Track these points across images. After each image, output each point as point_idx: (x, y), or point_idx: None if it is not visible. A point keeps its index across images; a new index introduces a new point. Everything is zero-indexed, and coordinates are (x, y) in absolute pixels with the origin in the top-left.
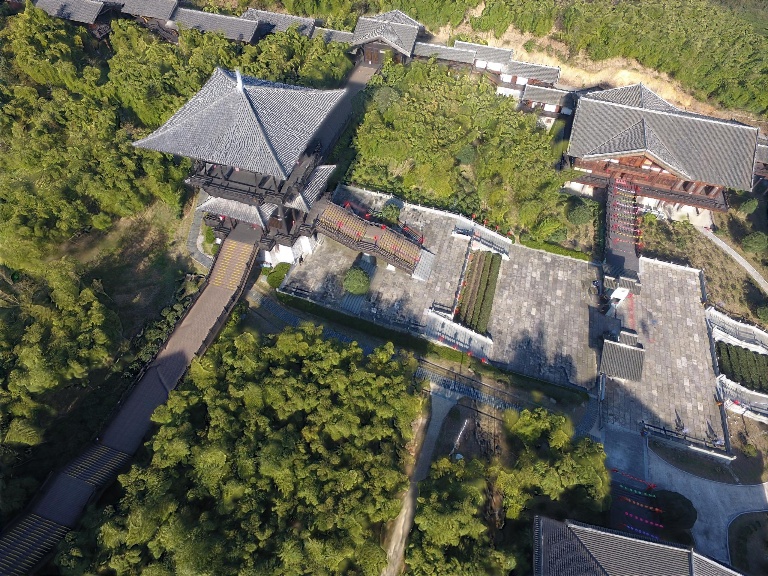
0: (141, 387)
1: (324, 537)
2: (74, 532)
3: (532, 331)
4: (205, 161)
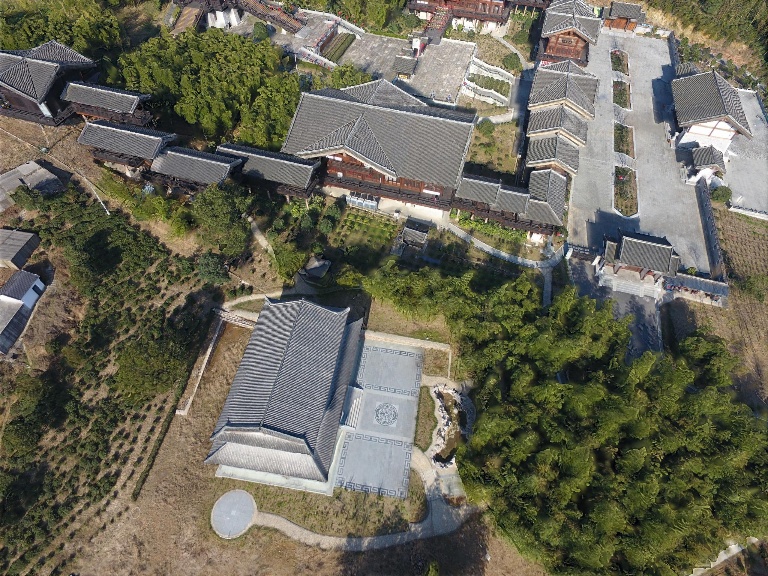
0: None
1: None
2: None
3: (364, 64)
4: None
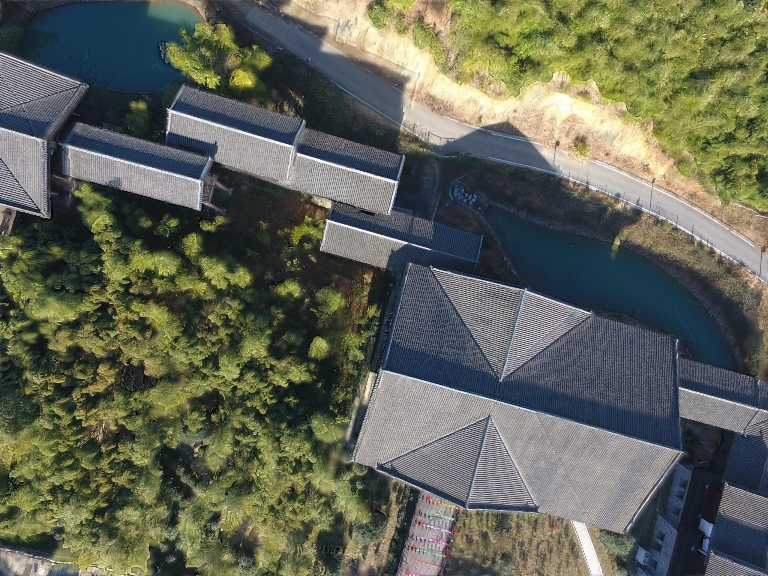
0: None
1: None
2: None
3: None
4: None
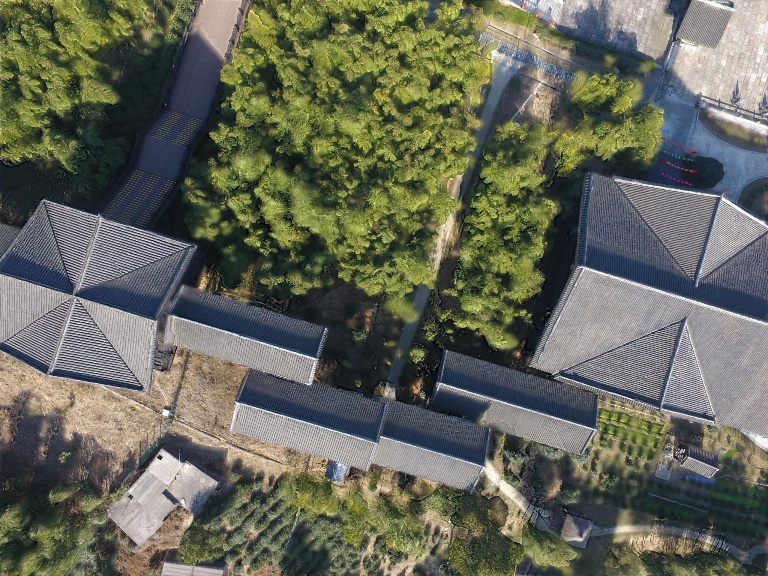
0: (190, 50)
1: (403, 187)
2: (190, 178)
3: None
4: None
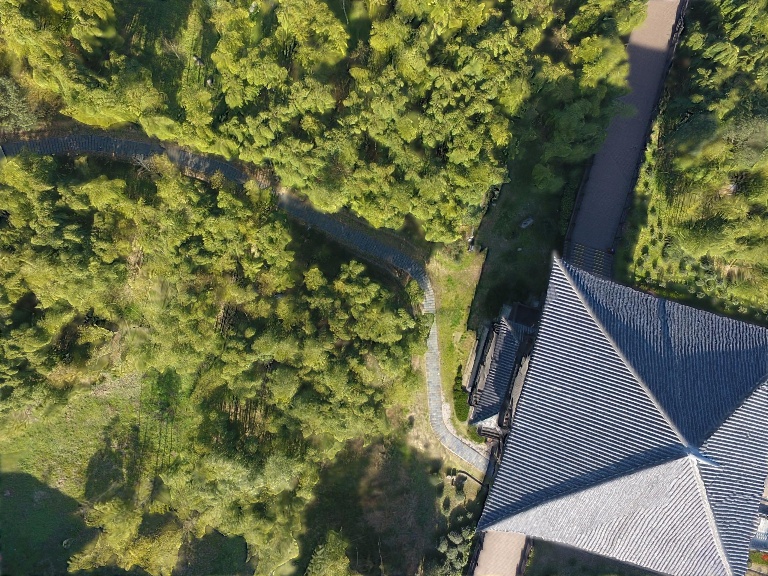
0: None
1: None
2: None
3: None
4: (598, 552)
